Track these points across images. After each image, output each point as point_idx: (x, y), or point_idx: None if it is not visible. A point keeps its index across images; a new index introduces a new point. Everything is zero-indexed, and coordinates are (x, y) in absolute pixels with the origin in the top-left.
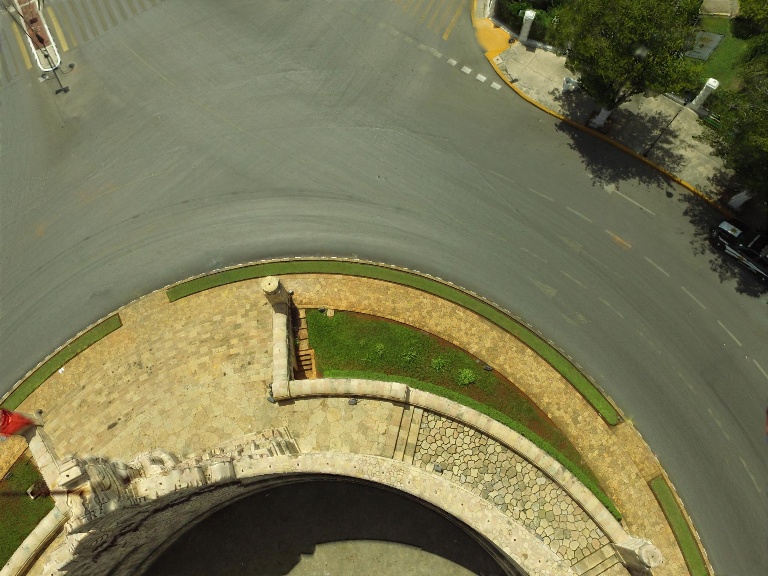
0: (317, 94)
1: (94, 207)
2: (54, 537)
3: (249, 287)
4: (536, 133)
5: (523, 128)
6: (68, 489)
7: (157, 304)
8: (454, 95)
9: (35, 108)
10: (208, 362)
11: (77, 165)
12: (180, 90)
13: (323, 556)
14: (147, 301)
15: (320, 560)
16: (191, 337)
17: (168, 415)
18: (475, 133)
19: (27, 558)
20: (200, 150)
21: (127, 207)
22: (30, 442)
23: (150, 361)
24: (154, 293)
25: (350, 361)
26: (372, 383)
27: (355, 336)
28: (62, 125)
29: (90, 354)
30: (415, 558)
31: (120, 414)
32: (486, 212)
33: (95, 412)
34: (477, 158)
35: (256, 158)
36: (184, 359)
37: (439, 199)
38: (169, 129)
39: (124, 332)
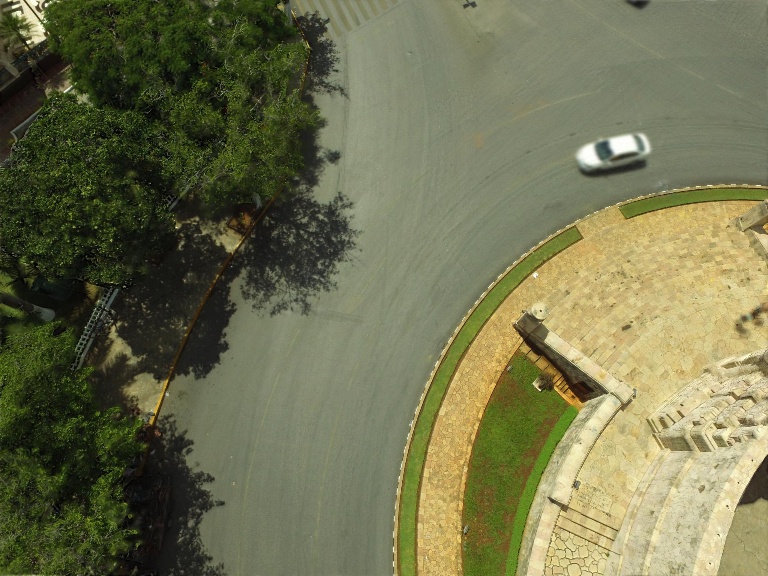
0: (732, 26)
1: (529, 122)
2: (607, 423)
3: (705, 210)
4: None
5: None
6: None
7: (613, 220)
8: None
9: (446, 21)
10: (703, 275)
11: (502, 80)
12: (590, 13)
13: None
14: (602, 216)
15: None
16: (669, 252)
17: (689, 320)
18: None
19: (595, 439)
20: (624, 74)
21: (562, 124)
22: (547, 337)
23: (633, 272)
24: (607, 209)
25: None
26: None
27: None
28: (478, 40)
29: (560, 262)
30: None
31: (628, 317)
32: None
33: (599, 314)
34: None
35: (683, 85)
36: (673, 271)
37: None
38: (587, 51)
39: (589, 244)
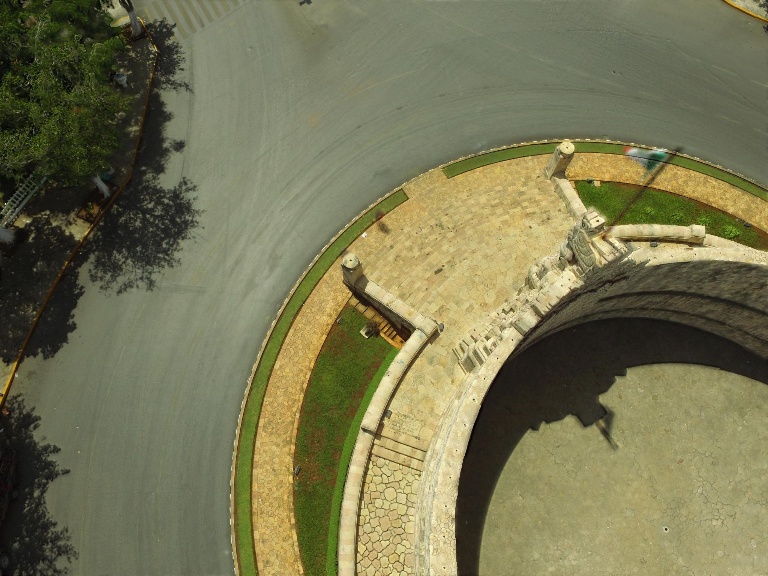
0: (542, 3)
1: (359, 101)
2: (417, 357)
3: (518, 164)
4: (748, 34)
5: (735, 30)
6: (591, 235)
7: (436, 180)
8: (668, 3)
9: (284, 18)
10: (509, 220)
11: (335, 66)
12: (415, 1)
13: (635, 377)
14: (426, 178)
15: (633, 380)
16: (482, 203)
17: (492, 259)
18: (693, 35)
19: (402, 371)
20: (445, 52)
21: (389, 100)
22: (366, 287)
23: (450, 223)
24: (431, 171)
25: (624, 222)
26: (672, 227)
27: (624, 202)
28: (312, 32)
29: (387, 222)
30: (716, 376)
31: (441, 263)
32: (717, 100)
33: (416, 263)
34: (699, 55)
35: (498, 58)
36: (484, 219)
37: (672, 90)
38: (412, 34)
39: (414, 203)
